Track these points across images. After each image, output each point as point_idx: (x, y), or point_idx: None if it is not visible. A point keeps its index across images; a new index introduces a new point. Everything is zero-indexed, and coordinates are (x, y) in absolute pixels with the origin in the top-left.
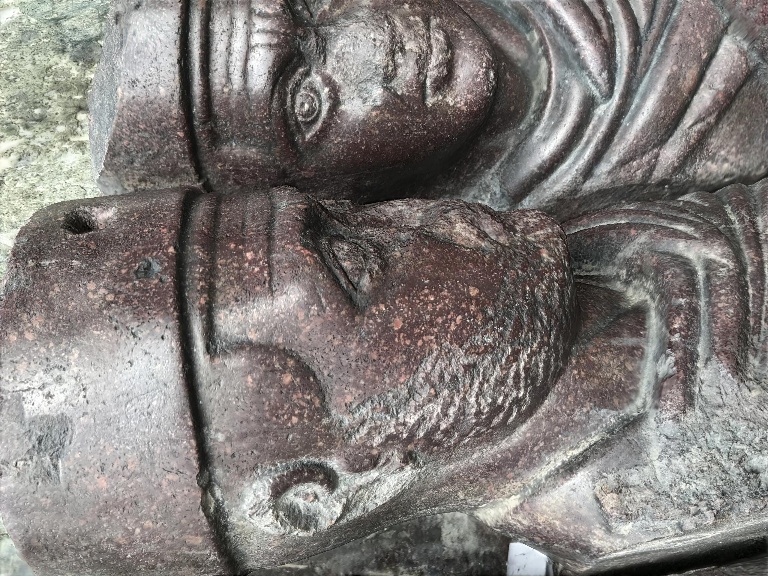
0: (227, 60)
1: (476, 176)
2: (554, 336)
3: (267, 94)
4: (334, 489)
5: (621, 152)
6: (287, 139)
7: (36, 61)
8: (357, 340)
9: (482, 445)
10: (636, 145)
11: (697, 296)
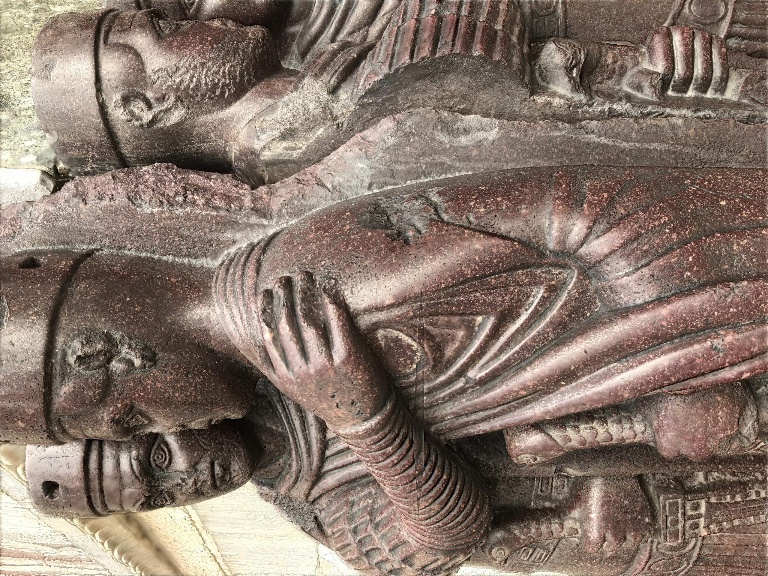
0: None
1: (289, 47)
2: (246, 63)
3: None
4: (150, 109)
5: (348, 27)
6: (181, 11)
7: None
8: (158, 47)
9: (216, 107)
10: (354, 24)
11: None
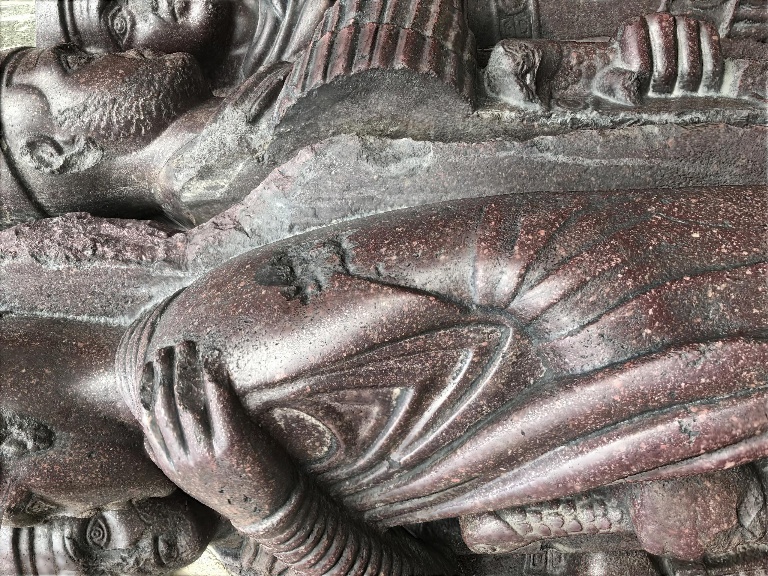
0: (80, 4)
1: (237, 71)
2: (162, 95)
3: (97, 19)
4: (61, 154)
5: (292, 46)
6: (113, 43)
7: None
8: (64, 85)
9: (134, 147)
10: (299, 41)
11: None
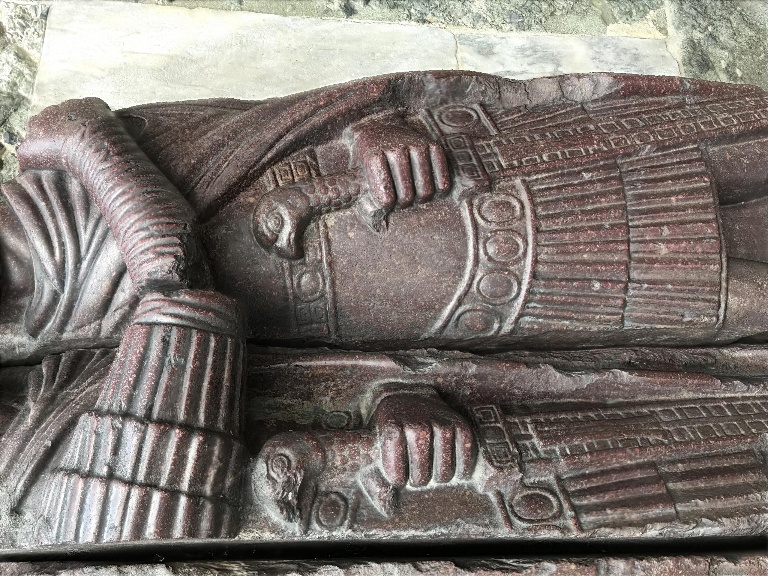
0: None
1: (20, 316)
2: None
3: None
4: None
5: (75, 322)
6: None
7: None
8: None
9: None
10: (82, 319)
11: (11, 437)
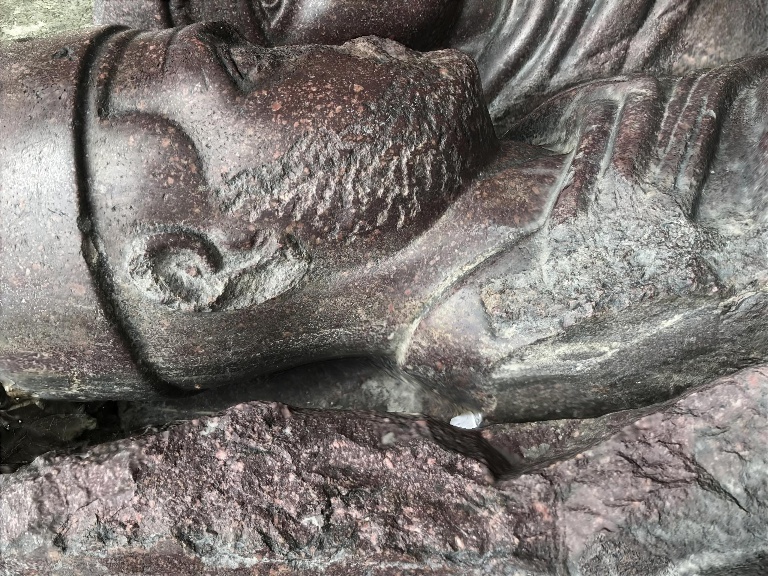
0: None
1: None
2: (445, 143)
3: None
4: (218, 269)
5: (587, 43)
6: (253, 25)
7: (80, 3)
8: (236, 117)
9: (374, 252)
10: (601, 35)
11: (611, 123)
